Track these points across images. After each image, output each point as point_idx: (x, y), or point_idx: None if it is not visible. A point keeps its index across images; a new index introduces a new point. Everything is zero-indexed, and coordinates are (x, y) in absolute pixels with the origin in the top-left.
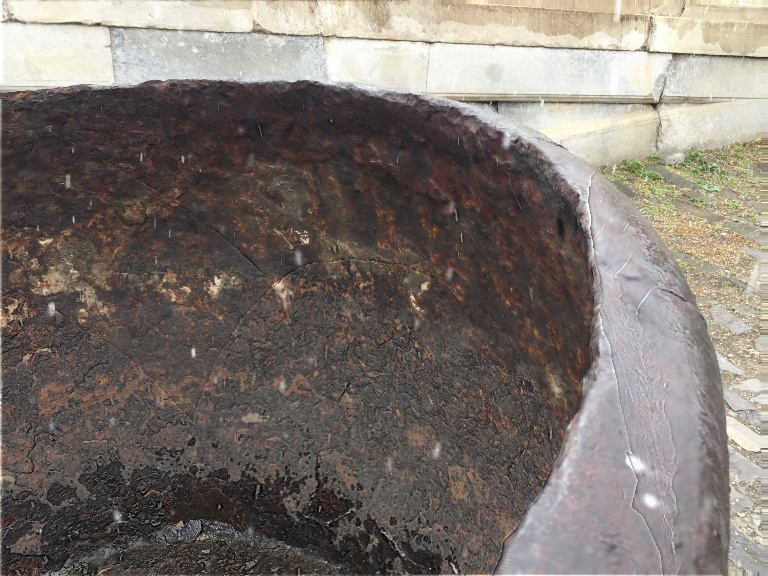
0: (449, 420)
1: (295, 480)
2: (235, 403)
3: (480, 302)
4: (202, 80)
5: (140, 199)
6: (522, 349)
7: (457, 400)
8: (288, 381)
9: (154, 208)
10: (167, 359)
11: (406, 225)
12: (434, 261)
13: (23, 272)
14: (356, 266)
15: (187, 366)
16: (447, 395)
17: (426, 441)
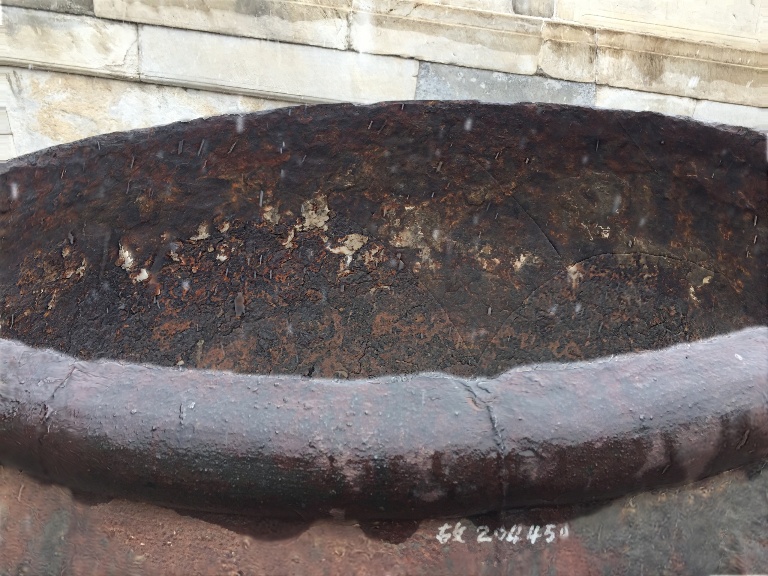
0: None
1: None
2: (514, 356)
3: (758, 294)
4: (563, 105)
5: (484, 187)
6: None
7: None
8: (562, 346)
9: (492, 195)
10: (468, 312)
11: (703, 229)
12: (721, 259)
13: (388, 227)
14: (645, 260)
15: (482, 320)
16: None
17: None
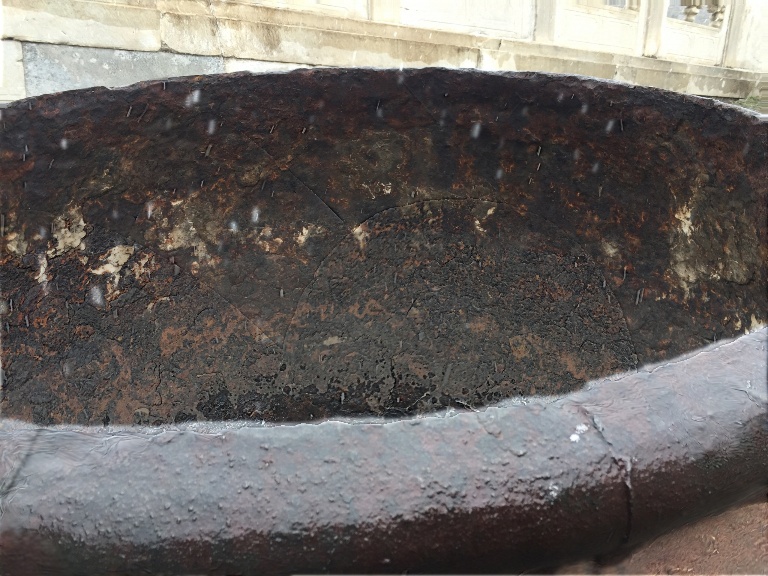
0: (508, 305)
1: (375, 382)
2: (317, 331)
3: (542, 212)
4: (341, 69)
5: (258, 165)
6: (579, 235)
7: (515, 289)
8: (362, 306)
9: (267, 172)
10: (260, 300)
11: (484, 167)
12: (504, 190)
13: (155, 230)
14: (429, 206)
15: (276, 305)
16: (505, 288)
17: (488, 326)
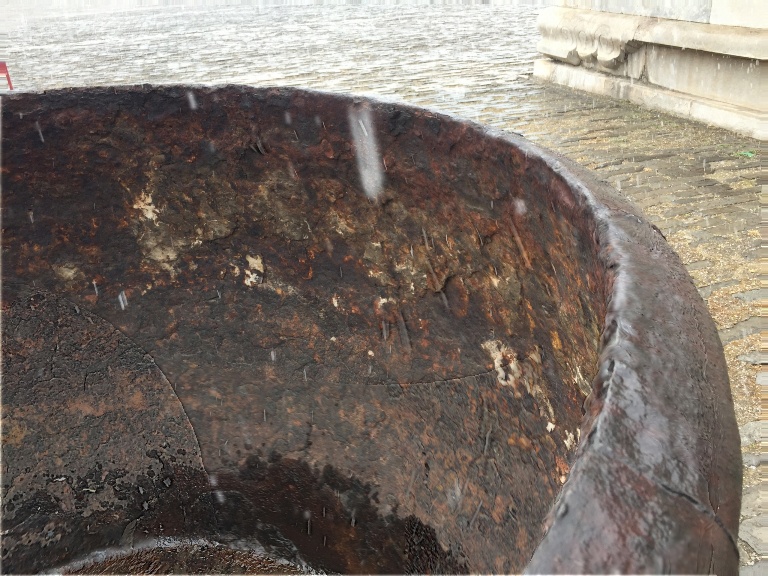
0: None
1: None
2: None
3: None
4: None
5: None
6: (22, 275)
7: None
8: None
9: None
10: None
11: None
12: None
13: None
14: None
15: None
16: None
17: None
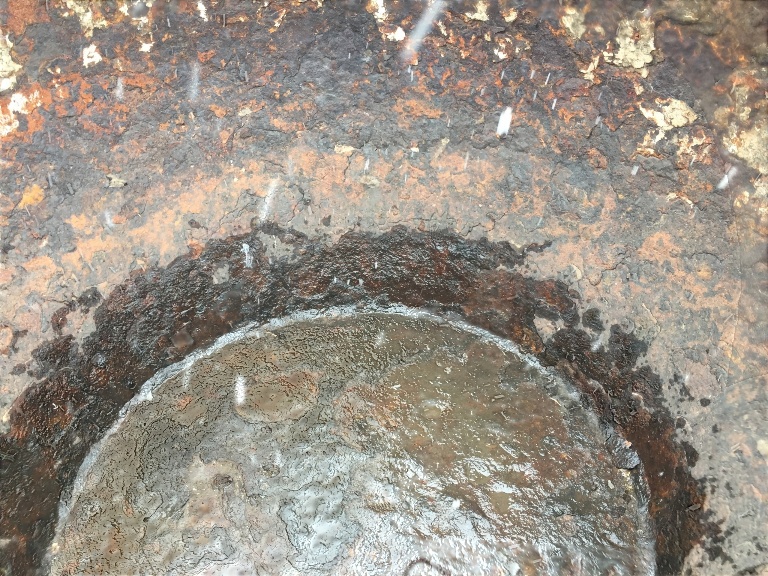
0: None
1: (723, 547)
2: None
3: None
4: None
5: None
6: None
7: None
8: None
9: None
10: (767, 312)
11: None
12: None
13: (731, 114)
14: None
15: None
16: None
17: None
